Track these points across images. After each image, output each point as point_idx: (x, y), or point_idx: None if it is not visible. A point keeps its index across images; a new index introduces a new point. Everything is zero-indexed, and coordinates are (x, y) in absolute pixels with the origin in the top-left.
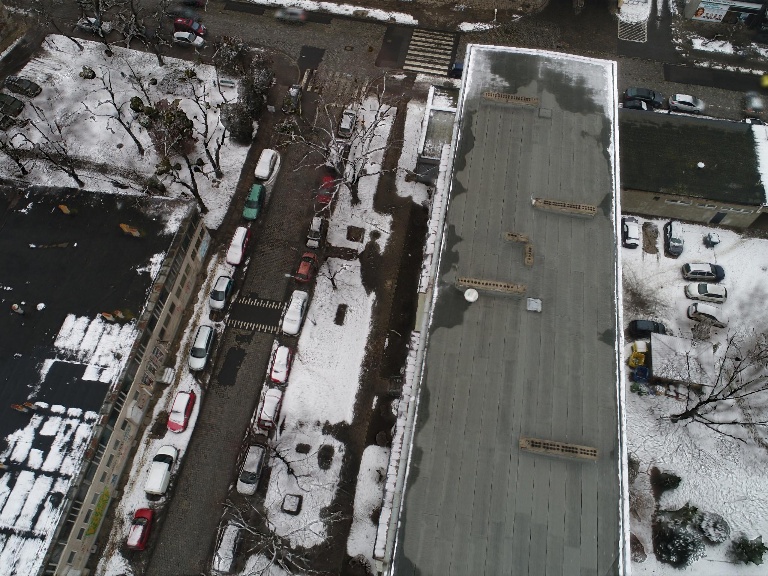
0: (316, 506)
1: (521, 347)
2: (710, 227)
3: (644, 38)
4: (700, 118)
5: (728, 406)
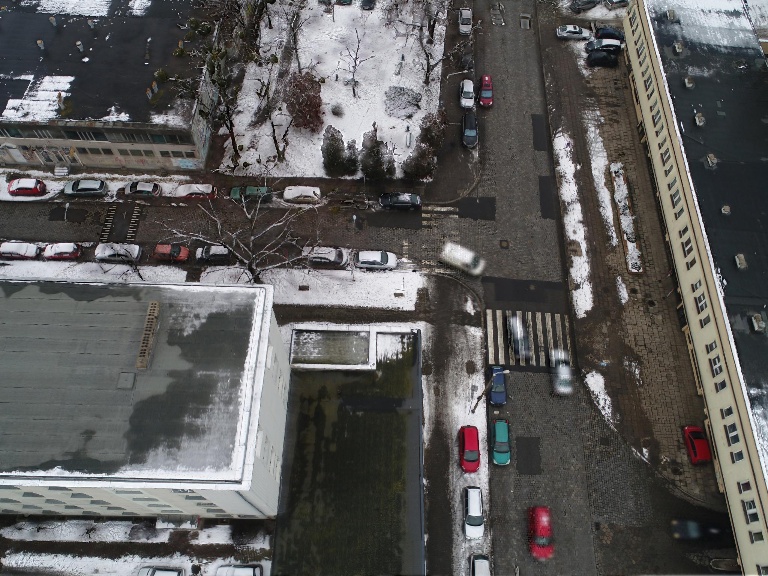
0: None
1: None
2: None
3: None
4: None
5: None
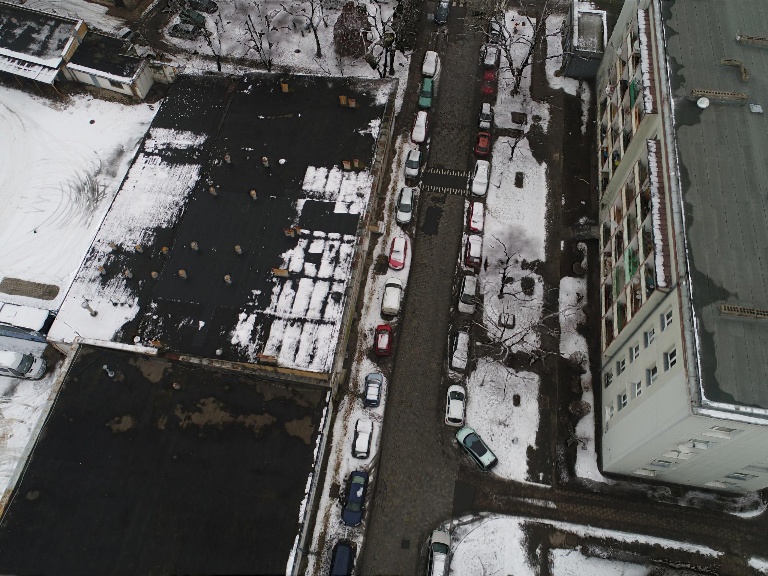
0: (528, 322)
1: (753, 136)
2: None
3: None
4: None
5: None
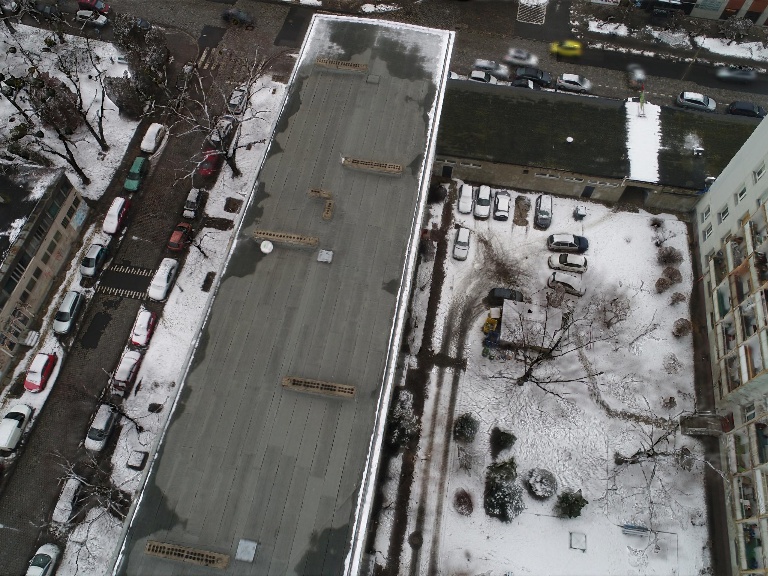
0: None
1: (305, 295)
2: (581, 201)
3: (542, 20)
4: (576, 95)
5: (575, 370)
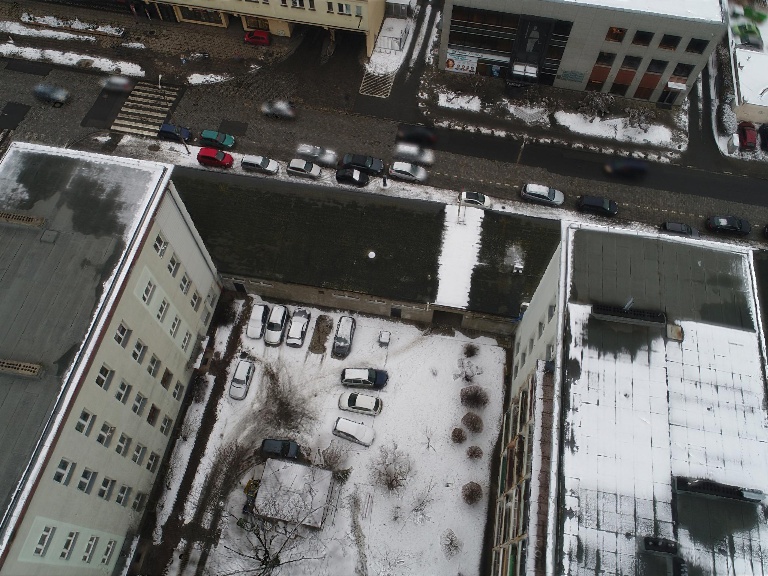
0: None
1: None
2: (391, 321)
3: (387, 93)
4: (391, 197)
5: None
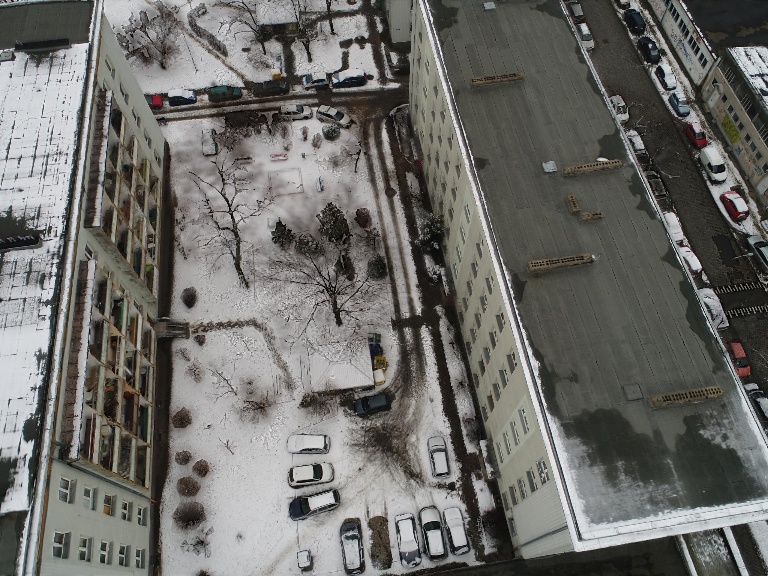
0: None
1: (546, 134)
2: None
3: None
4: None
5: None
